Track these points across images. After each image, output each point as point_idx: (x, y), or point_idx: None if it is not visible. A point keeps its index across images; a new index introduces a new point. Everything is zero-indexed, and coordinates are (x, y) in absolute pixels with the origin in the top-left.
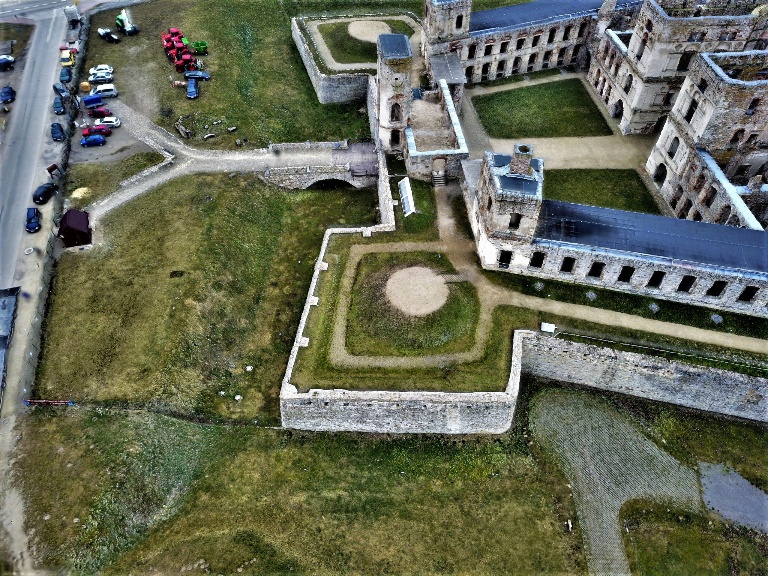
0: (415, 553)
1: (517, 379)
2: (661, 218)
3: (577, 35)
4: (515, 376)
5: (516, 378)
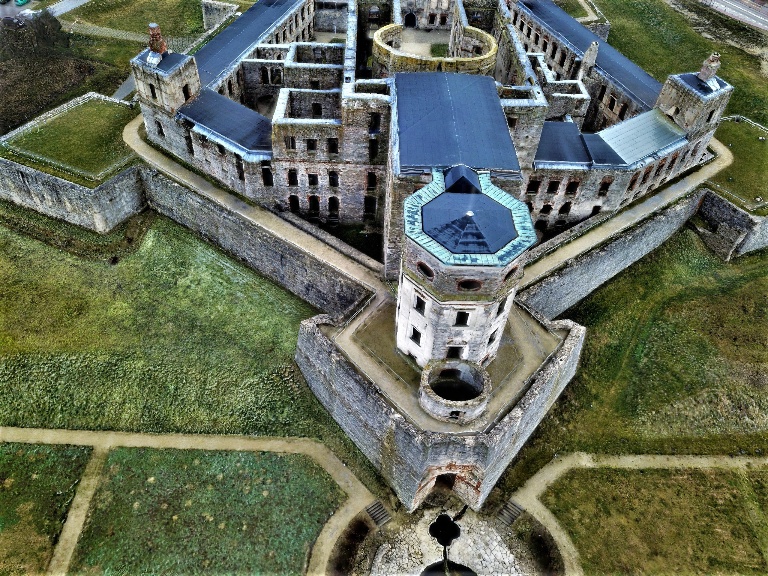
0: (164, 6)
1: (211, 2)
2: (278, 16)
3: (568, 69)
4: (213, 1)
5: (212, 1)
